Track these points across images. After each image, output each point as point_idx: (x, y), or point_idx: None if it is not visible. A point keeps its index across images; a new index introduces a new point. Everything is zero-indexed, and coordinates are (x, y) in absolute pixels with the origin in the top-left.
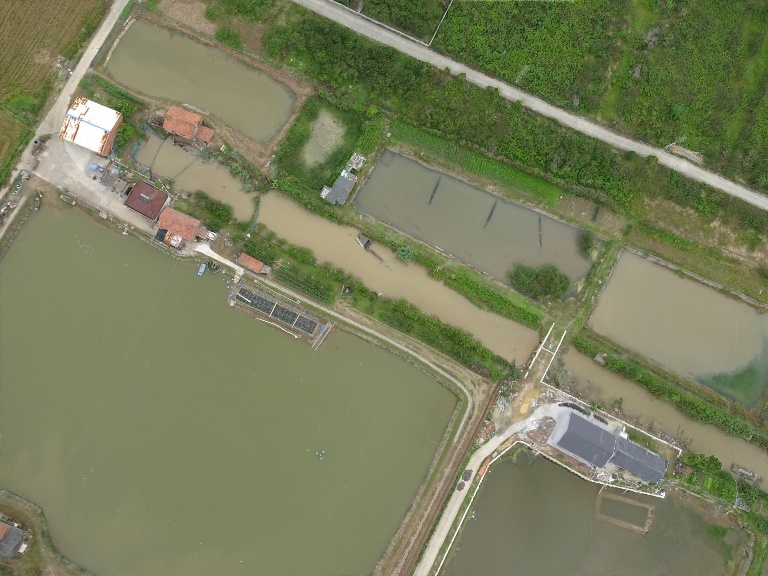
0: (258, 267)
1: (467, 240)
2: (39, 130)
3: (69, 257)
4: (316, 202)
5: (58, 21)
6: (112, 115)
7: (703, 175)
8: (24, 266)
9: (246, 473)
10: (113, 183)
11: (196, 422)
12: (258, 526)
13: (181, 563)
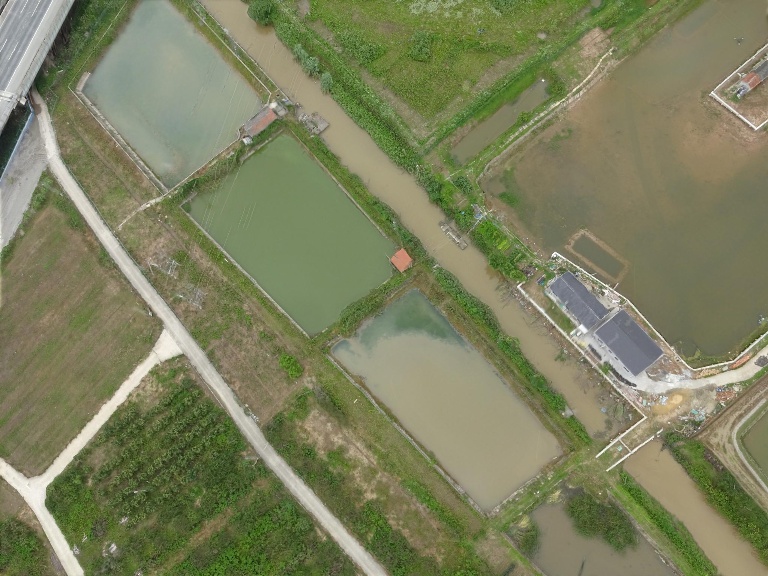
0: None
1: None
2: None
3: None
4: None
5: None
6: None
7: (362, 560)
8: None
9: None
10: None
11: None
12: None
13: None
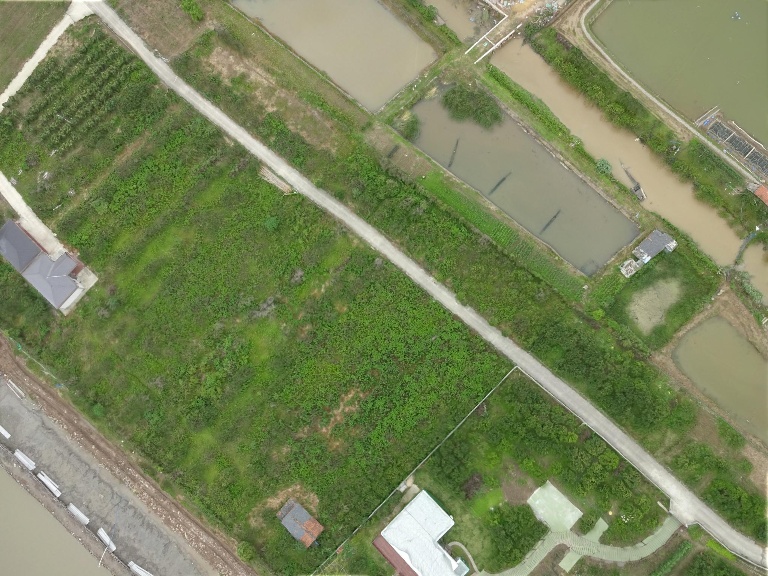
0: (761, 191)
1: (532, 166)
2: None
3: None
4: (681, 241)
5: None
6: None
7: (266, 156)
8: None
9: None
10: None
11: None
12: None
13: None
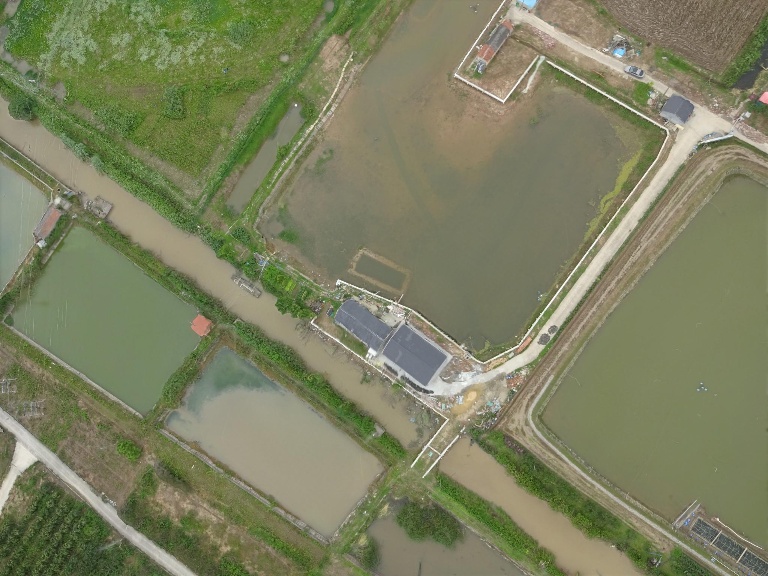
0: None
1: None
2: None
3: None
4: None
5: None
6: None
7: None
8: None
9: None
10: None
11: None
12: None
13: None
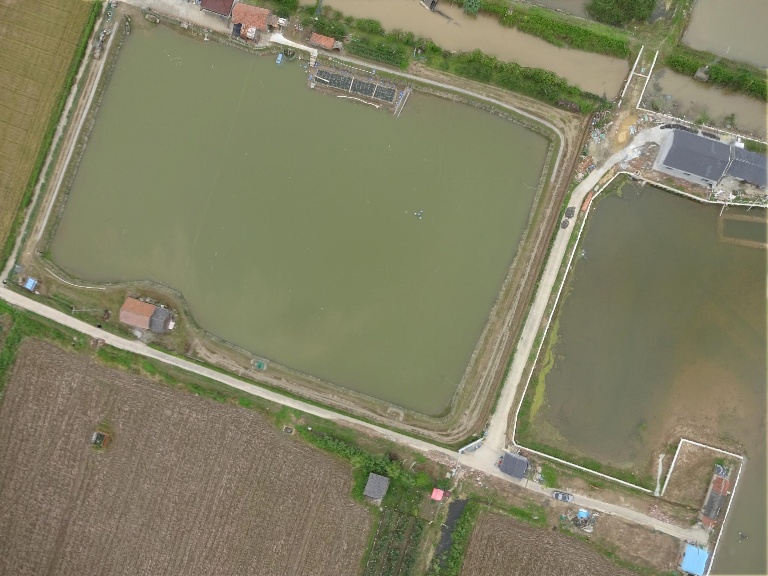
0: (330, 43)
1: None
2: None
3: (163, 70)
4: None
5: None
6: None
7: None
8: (128, 86)
9: (352, 240)
10: None
11: (298, 199)
12: (371, 287)
13: (307, 327)
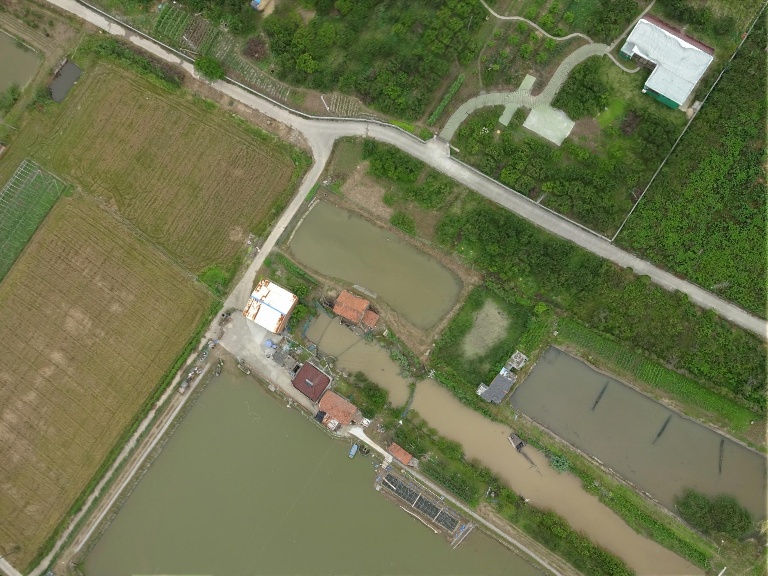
0: (406, 459)
1: (631, 455)
2: (227, 302)
3: (239, 422)
4: (471, 397)
5: (253, 201)
6: (289, 298)
7: None
8: (202, 426)
9: None
10: (283, 360)
11: None
12: None
13: None
